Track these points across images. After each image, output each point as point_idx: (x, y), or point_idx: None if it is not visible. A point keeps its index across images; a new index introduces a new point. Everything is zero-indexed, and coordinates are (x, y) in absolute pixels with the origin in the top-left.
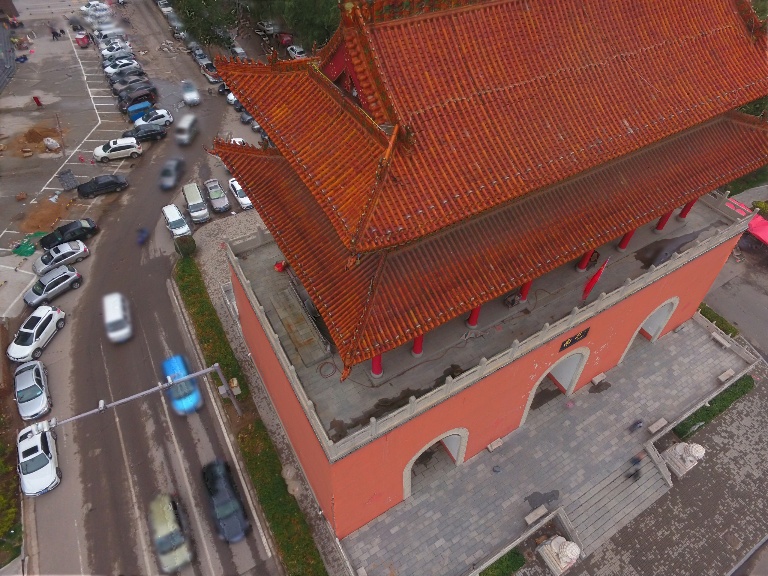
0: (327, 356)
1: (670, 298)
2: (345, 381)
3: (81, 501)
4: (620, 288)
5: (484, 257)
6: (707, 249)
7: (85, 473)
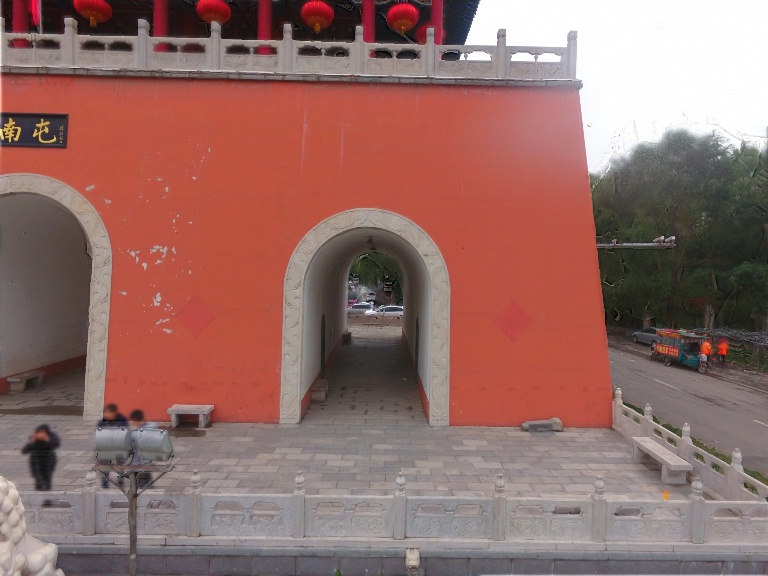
0: None
1: (379, 209)
2: None
3: None
4: (126, 37)
5: None
6: (423, 76)
7: None
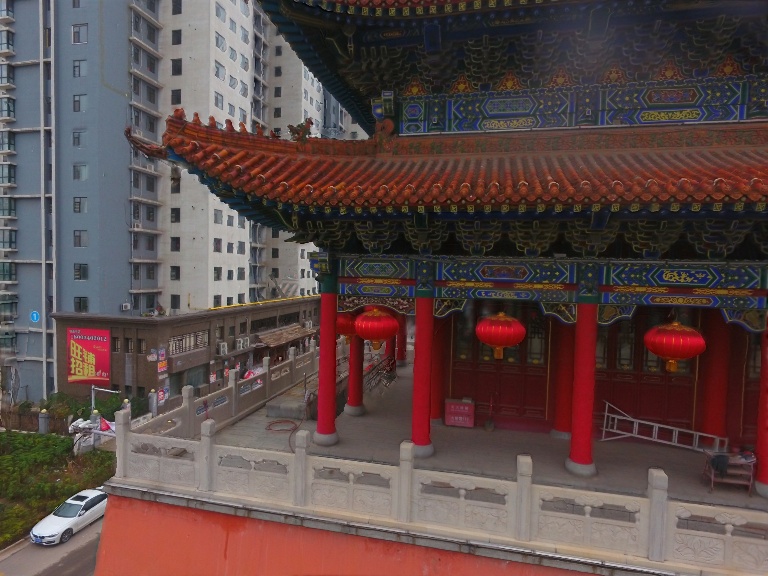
0: (301, 415)
1: None
2: (281, 441)
3: (36, 572)
4: None
5: (544, 174)
6: None
7: (76, 553)
